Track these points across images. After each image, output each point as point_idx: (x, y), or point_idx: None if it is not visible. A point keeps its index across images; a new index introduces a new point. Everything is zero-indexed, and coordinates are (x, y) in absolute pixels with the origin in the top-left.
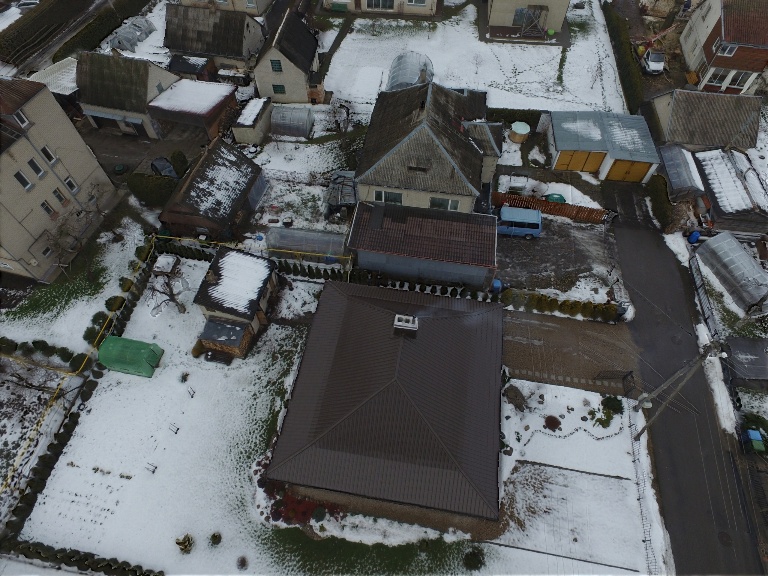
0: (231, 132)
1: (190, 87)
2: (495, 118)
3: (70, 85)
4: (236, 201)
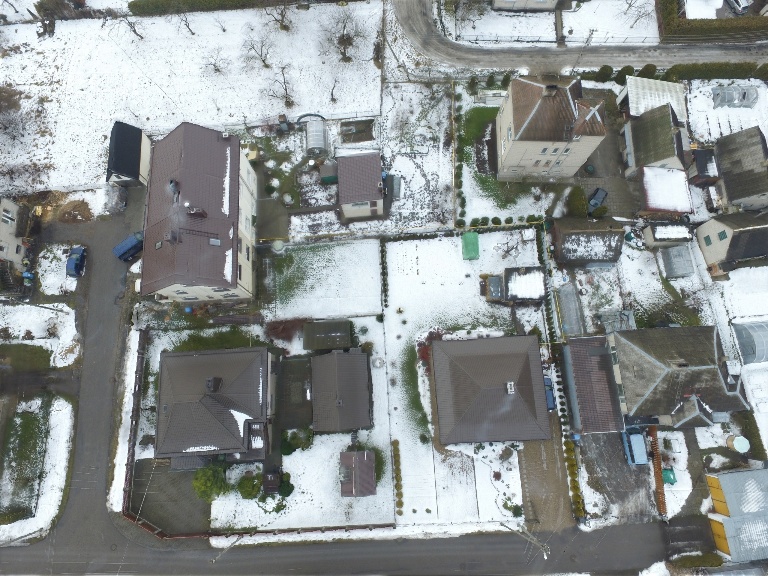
0: (650, 223)
1: (676, 182)
2: (742, 421)
3: (641, 109)
4: (582, 259)
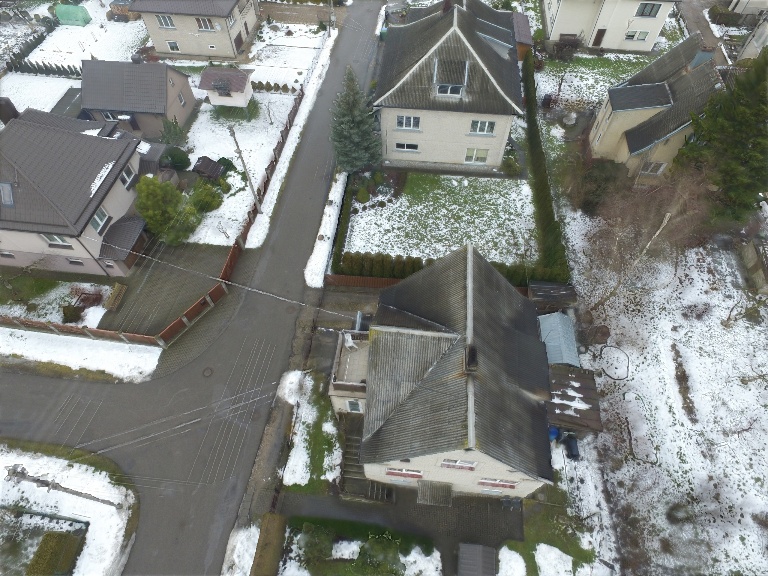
0: None
1: None
2: None
3: None
4: None
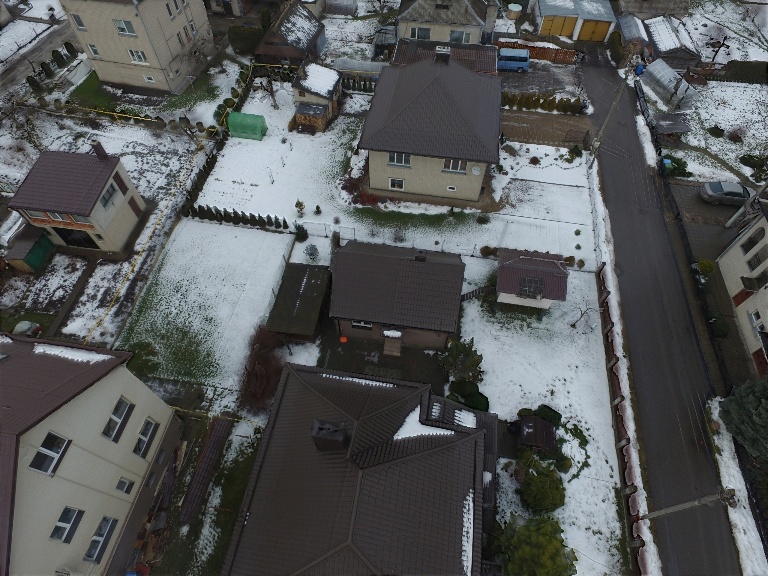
0: None
1: None
2: None
3: None
4: (310, 41)
